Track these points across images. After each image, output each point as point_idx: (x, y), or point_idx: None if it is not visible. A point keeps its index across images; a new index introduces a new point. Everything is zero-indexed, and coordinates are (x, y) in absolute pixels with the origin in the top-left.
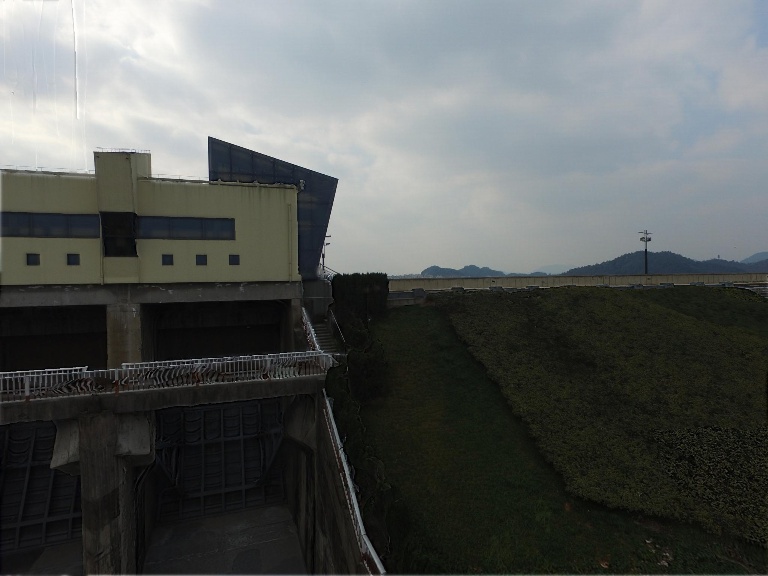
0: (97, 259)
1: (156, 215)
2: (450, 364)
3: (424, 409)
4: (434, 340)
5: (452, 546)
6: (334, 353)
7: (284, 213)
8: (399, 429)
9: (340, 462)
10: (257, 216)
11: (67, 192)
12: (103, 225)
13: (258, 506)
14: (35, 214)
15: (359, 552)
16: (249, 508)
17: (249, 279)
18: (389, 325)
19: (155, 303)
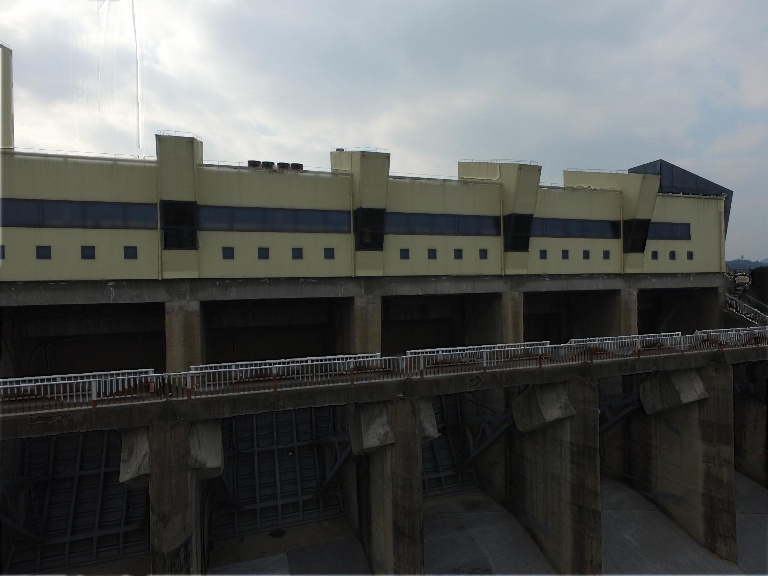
0: (618, 255)
1: None
2: None
3: None
4: None
5: None
6: None
7: (717, 219)
8: None
9: None
10: (702, 221)
11: (602, 204)
12: None
13: None
14: (587, 221)
15: None
16: None
17: (697, 271)
18: None
19: (645, 289)
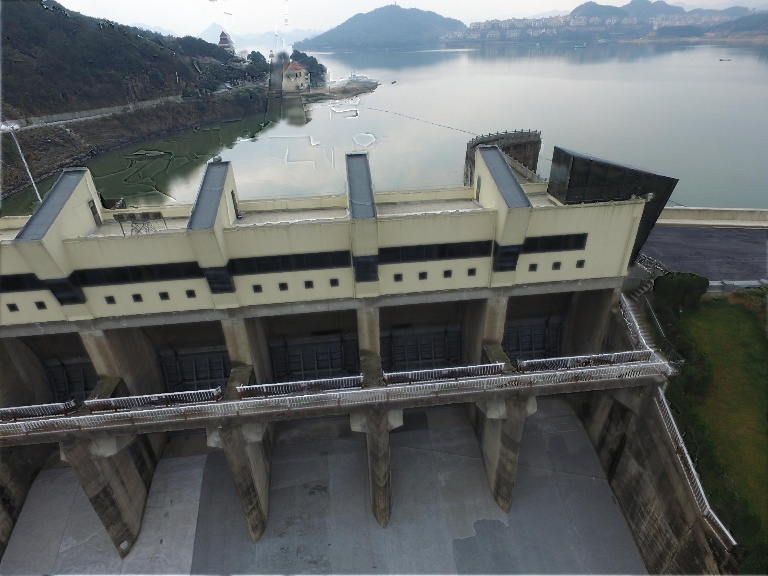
0: (487, 271)
1: (530, 236)
2: (763, 379)
3: (740, 416)
4: (747, 349)
5: (767, 526)
6: (648, 338)
7: (629, 225)
8: (719, 428)
9: (679, 449)
10: (606, 229)
11: (472, 226)
12: (500, 254)
13: (545, 397)
14: (451, 244)
15: (699, 511)
16: (539, 398)
17: (588, 277)
18: (702, 322)
19: None
